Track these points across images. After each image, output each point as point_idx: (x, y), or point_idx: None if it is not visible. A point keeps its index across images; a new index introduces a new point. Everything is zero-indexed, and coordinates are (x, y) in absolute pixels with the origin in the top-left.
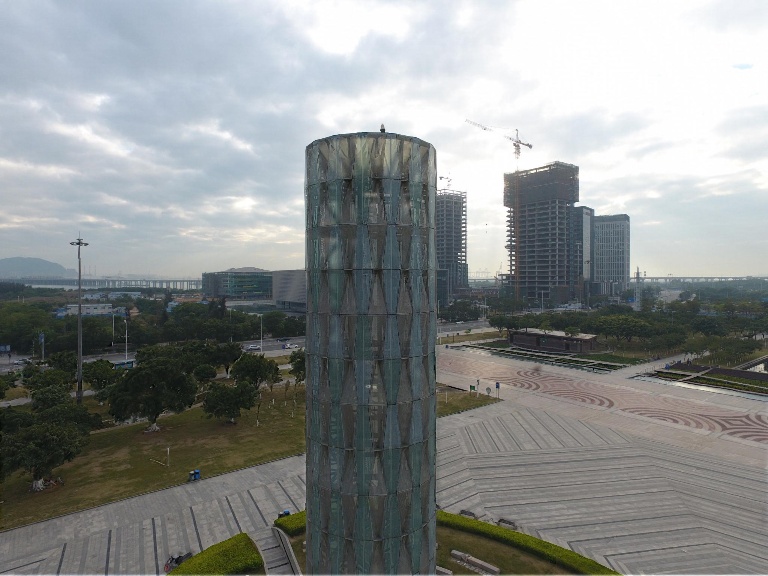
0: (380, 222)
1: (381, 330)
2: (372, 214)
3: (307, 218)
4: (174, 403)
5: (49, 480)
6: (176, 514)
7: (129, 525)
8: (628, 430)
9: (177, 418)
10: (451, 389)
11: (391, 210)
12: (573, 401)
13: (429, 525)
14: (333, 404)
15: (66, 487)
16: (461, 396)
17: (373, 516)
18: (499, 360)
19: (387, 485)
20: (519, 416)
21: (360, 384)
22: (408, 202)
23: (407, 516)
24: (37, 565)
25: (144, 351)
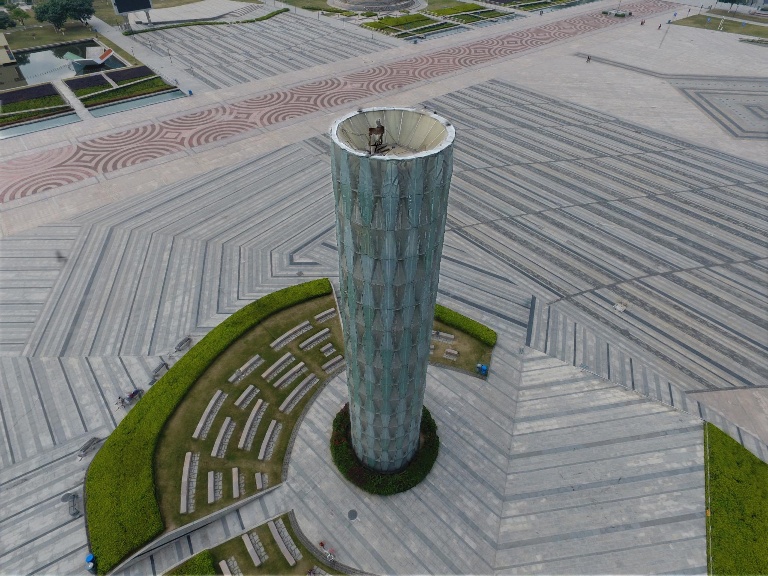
0: None
1: None
2: None
3: (419, 218)
4: None
5: None
6: None
7: None
8: (54, 217)
9: None
10: None
11: None
12: None
13: None
14: None
15: None
16: None
17: None
18: None
19: None
20: None
21: None
22: None
23: None
24: None
25: None
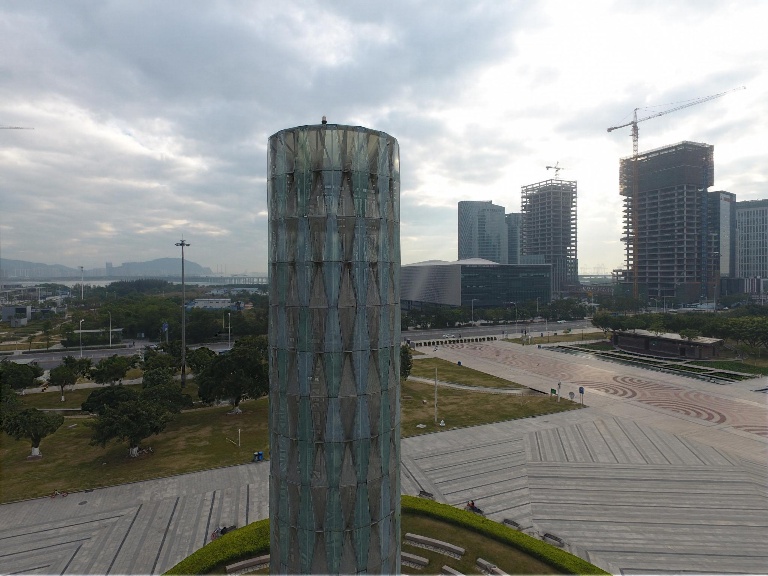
0: (321, 214)
1: (322, 322)
2: (313, 206)
3: None
4: (252, 389)
5: (143, 449)
6: (234, 490)
7: (194, 495)
8: (736, 451)
9: (259, 403)
10: (532, 391)
11: (333, 202)
12: (673, 413)
13: (381, 524)
14: (281, 394)
15: (155, 456)
16: (540, 399)
17: (315, 507)
18: (595, 363)
19: (329, 478)
20: (602, 425)
21: (303, 375)
22: (351, 193)
23: (352, 511)
24: (116, 519)
25: (240, 341)
